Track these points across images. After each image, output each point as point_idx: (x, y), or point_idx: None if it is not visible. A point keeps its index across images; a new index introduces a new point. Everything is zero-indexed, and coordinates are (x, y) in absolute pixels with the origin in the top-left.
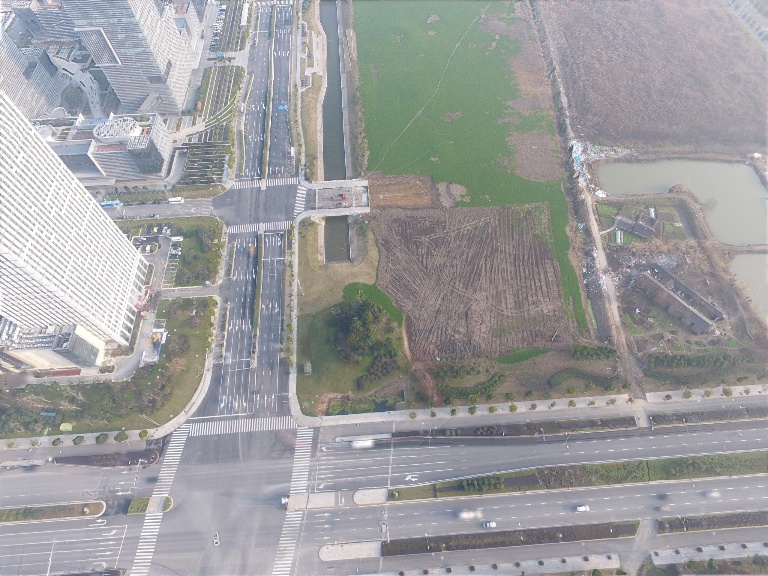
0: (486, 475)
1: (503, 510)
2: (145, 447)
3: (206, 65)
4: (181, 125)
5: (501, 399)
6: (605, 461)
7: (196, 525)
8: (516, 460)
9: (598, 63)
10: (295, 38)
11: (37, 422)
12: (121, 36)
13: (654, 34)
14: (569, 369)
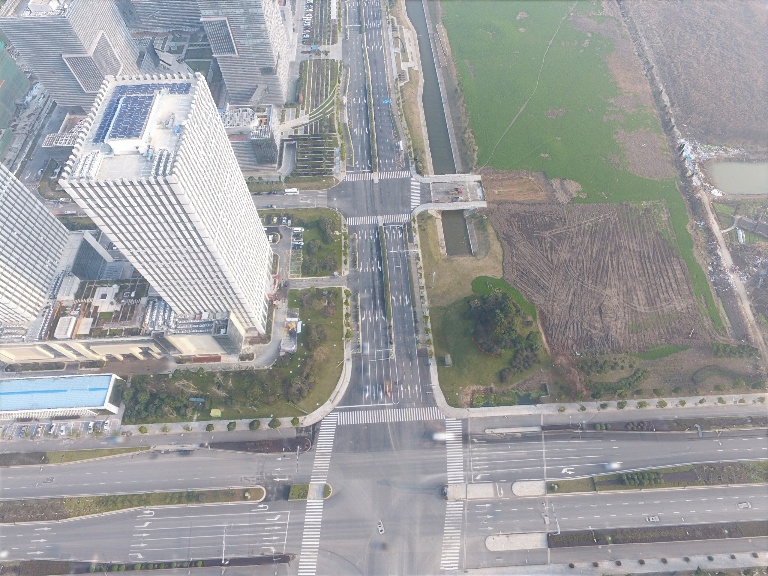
0: (642, 470)
1: (664, 505)
2: (296, 434)
3: (301, 58)
4: (285, 117)
5: (646, 395)
6: (760, 459)
7: (358, 512)
8: (670, 456)
9: (696, 62)
10: (386, 33)
11: (187, 407)
12: (244, 27)
13: (748, 34)
14: (711, 366)
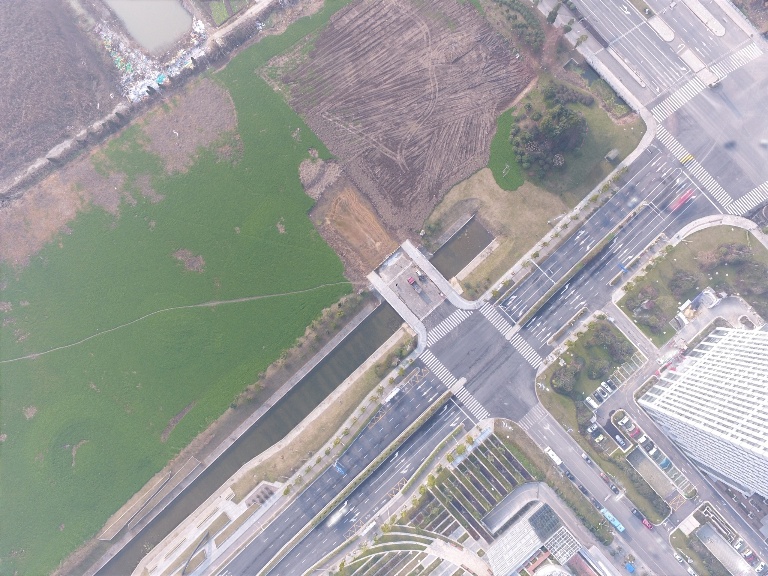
0: None
1: None
2: (767, 225)
3: None
4: (452, 575)
5: None
6: None
7: None
8: None
9: None
10: None
11: None
12: None
13: None
14: None
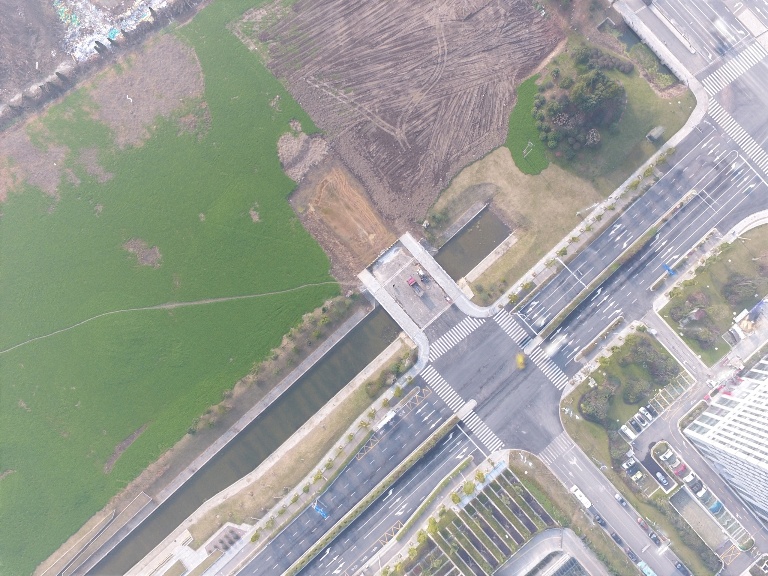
0: None
1: None
2: None
3: None
4: None
5: None
6: None
7: None
8: None
9: None
10: None
11: None
12: None
13: None
14: None
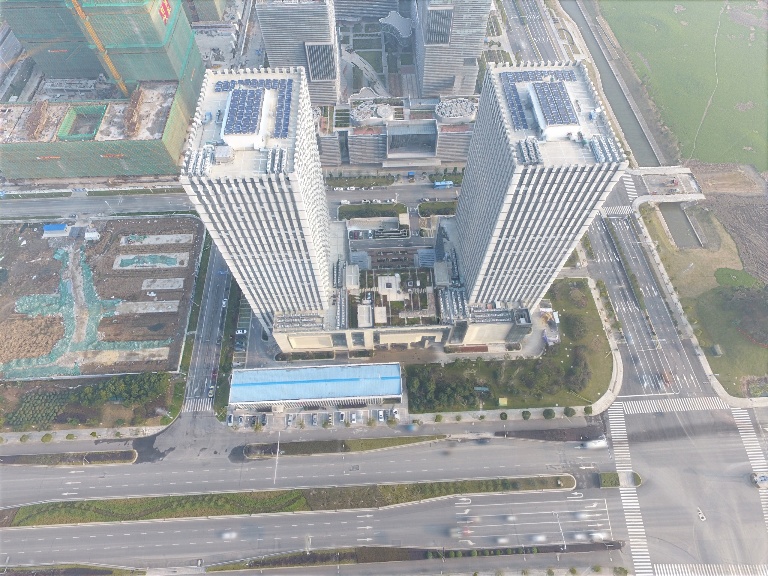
0: None
1: None
2: (587, 423)
3: None
4: None
5: None
6: None
7: (674, 500)
8: None
9: None
10: (548, 24)
11: (474, 396)
12: (466, 16)
13: None
14: None
